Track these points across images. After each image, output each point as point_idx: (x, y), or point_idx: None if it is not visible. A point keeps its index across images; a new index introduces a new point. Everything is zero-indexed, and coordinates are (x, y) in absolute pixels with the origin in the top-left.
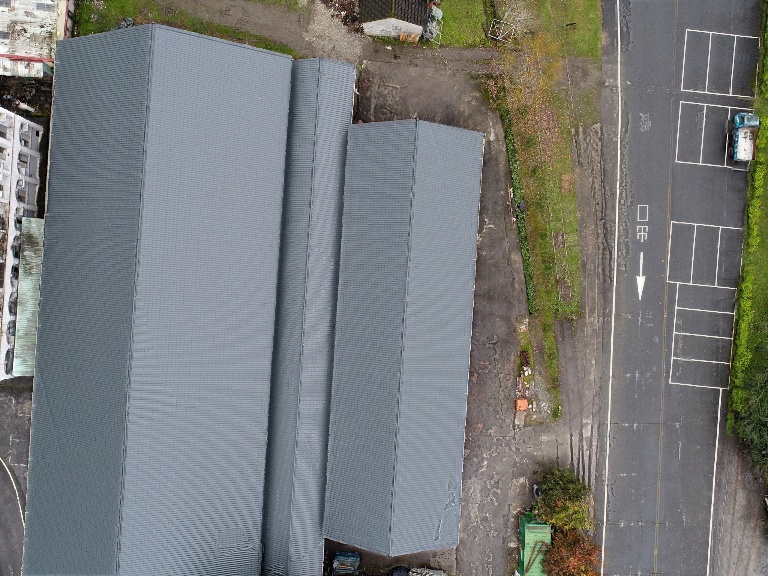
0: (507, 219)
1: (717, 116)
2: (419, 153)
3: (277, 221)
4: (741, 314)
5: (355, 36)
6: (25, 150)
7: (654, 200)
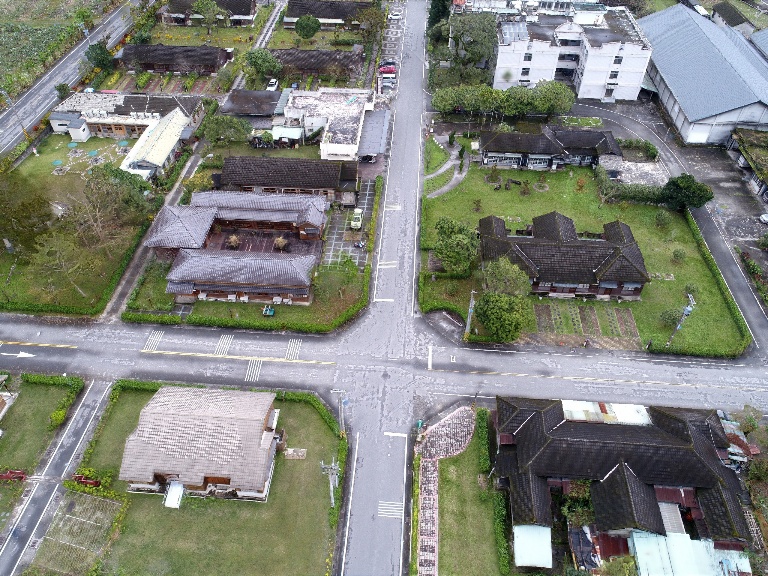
0: None
1: None
2: None
3: None
4: None
5: None
6: None
7: None
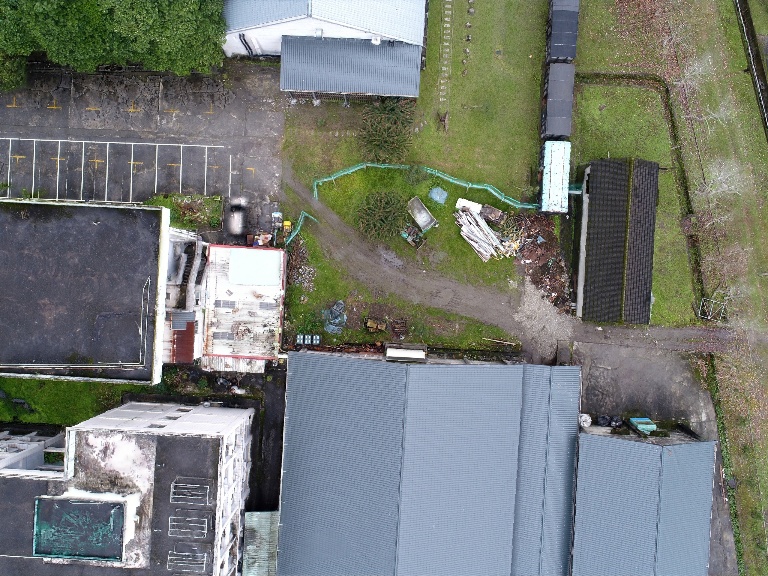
0: (719, 499)
1: None
2: (664, 479)
3: (510, 530)
4: None
5: (565, 317)
6: (246, 444)
7: None
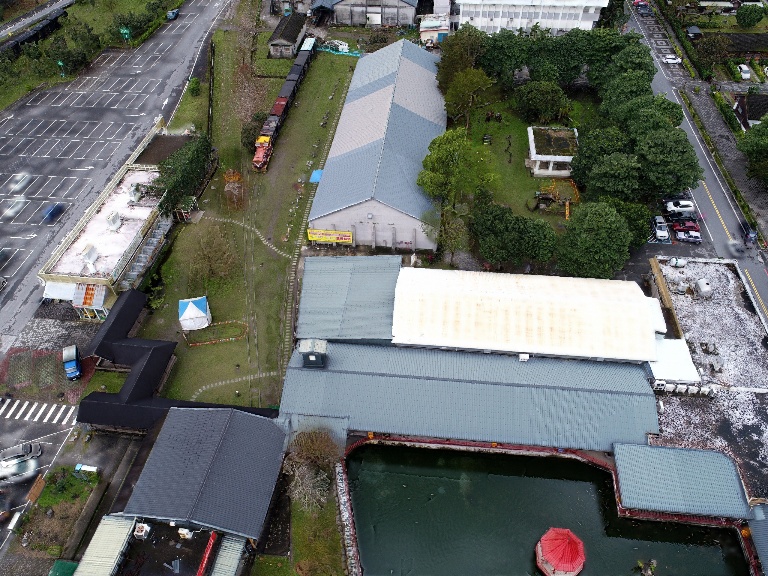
0: (264, 5)
1: None
2: None
3: None
4: None
5: None
6: None
7: (211, 8)
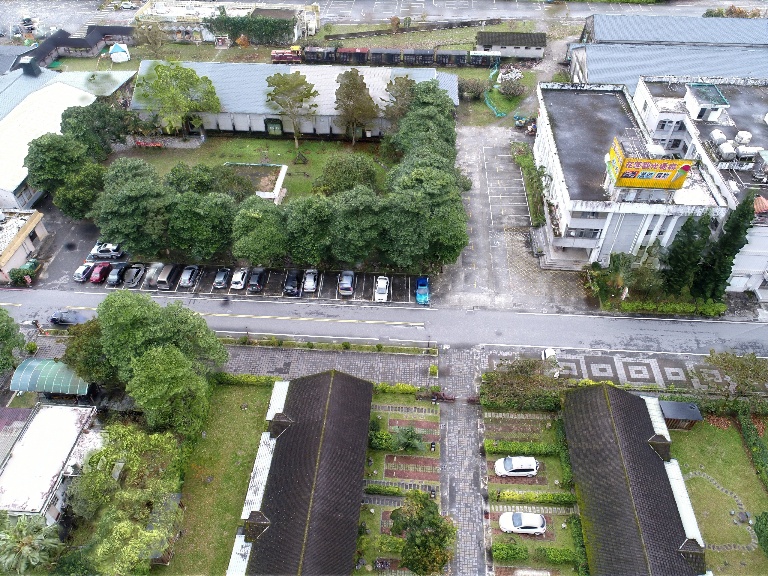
0: None
1: (548, 5)
2: None
3: None
4: (620, 1)
5: None
6: None
7: None
